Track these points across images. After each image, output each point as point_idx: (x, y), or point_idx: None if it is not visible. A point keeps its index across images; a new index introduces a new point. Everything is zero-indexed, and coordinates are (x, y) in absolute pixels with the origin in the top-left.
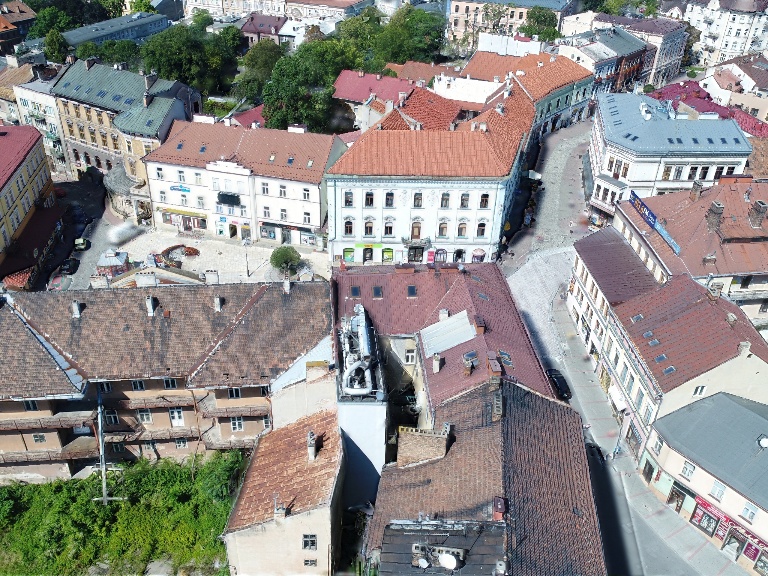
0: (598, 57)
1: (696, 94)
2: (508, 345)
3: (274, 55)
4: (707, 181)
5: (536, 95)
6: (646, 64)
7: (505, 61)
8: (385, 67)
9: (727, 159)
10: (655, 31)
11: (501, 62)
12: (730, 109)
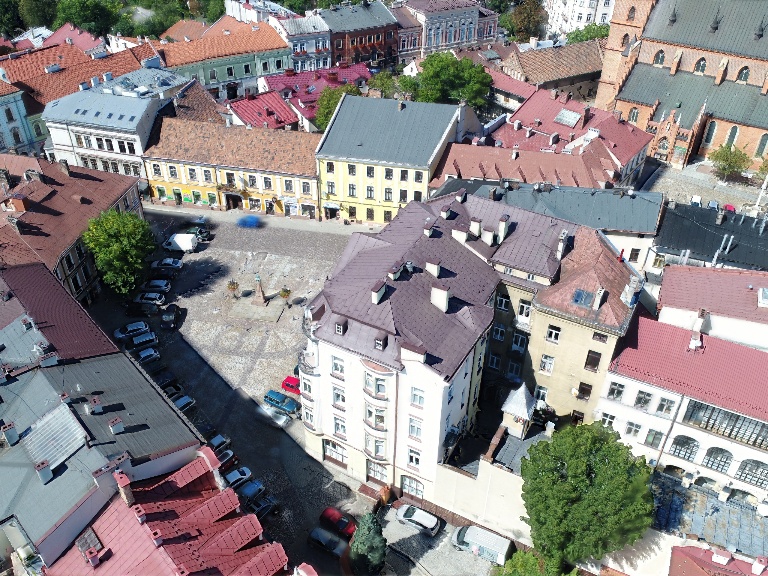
0: (299, 30)
1: (329, 76)
2: None
3: (43, 5)
4: (116, 153)
5: (178, 61)
6: (407, 42)
7: (237, 27)
8: (176, 24)
9: (123, 134)
10: (421, 8)
11: (234, 28)
12: (262, 92)
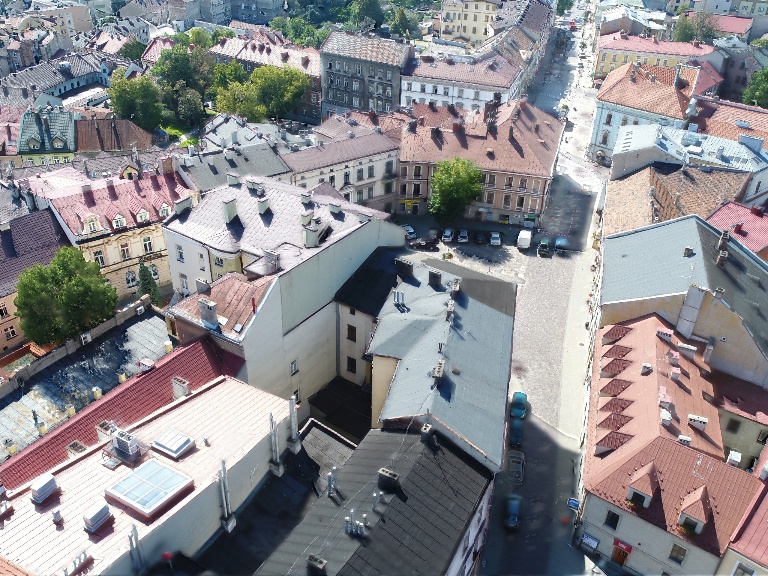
0: None
1: None
2: (443, 69)
3: None
4: None
5: None
6: None
7: None
8: None
9: None
10: None
11: None
12: None
